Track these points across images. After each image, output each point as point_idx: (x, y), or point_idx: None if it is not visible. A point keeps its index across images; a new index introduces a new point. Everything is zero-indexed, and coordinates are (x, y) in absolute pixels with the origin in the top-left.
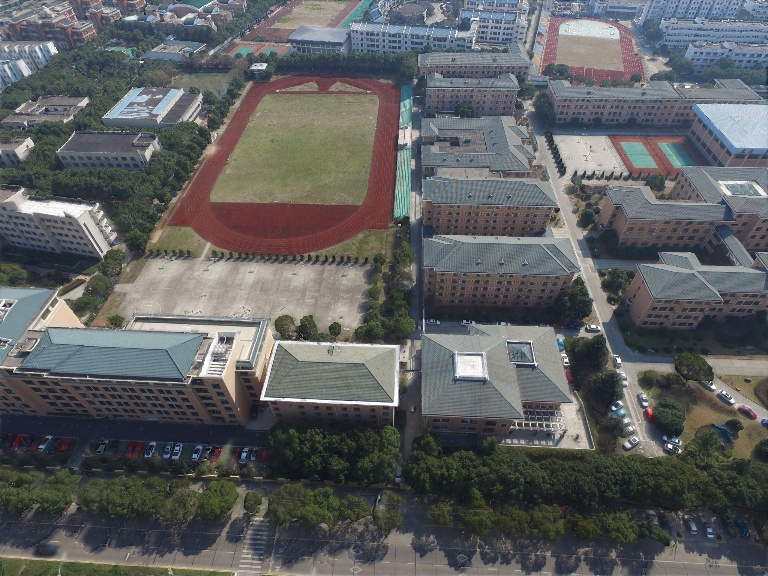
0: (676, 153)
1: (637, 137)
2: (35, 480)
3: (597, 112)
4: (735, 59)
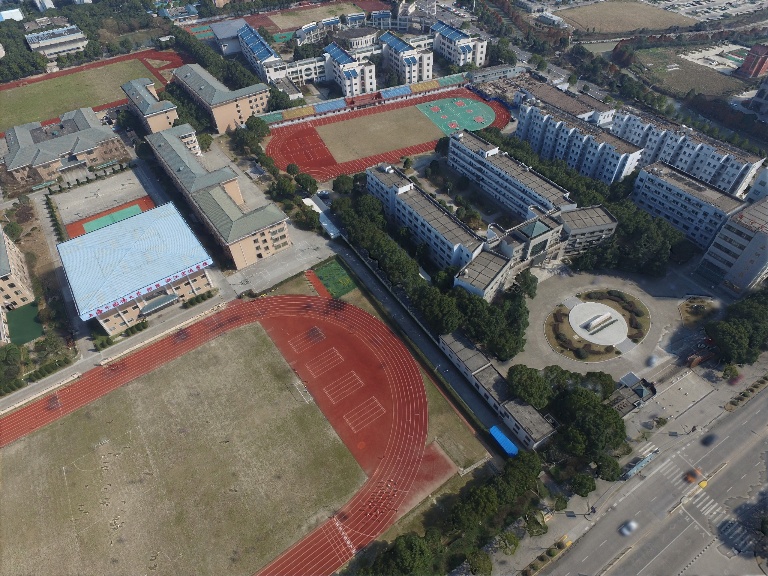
0: None
1: None
2: None
3: None
4: (399, 208)
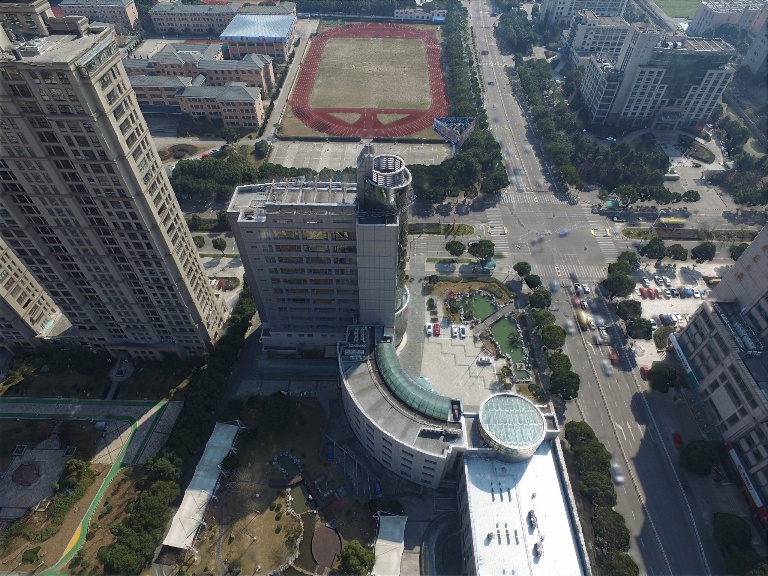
0: None
1: (206, 40)
2: None
3: (184, 24)
4: None
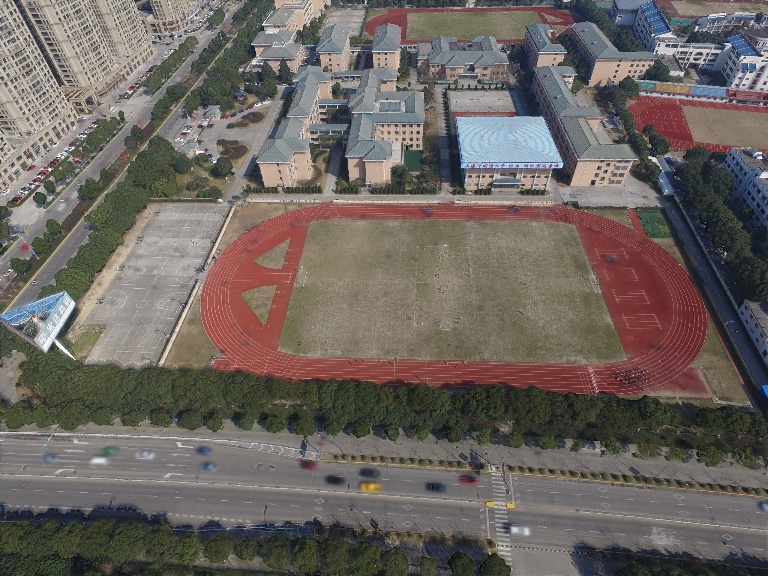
0: None
1: None
2: (266, 6)
3: (540, 97)
4: (751, 191)
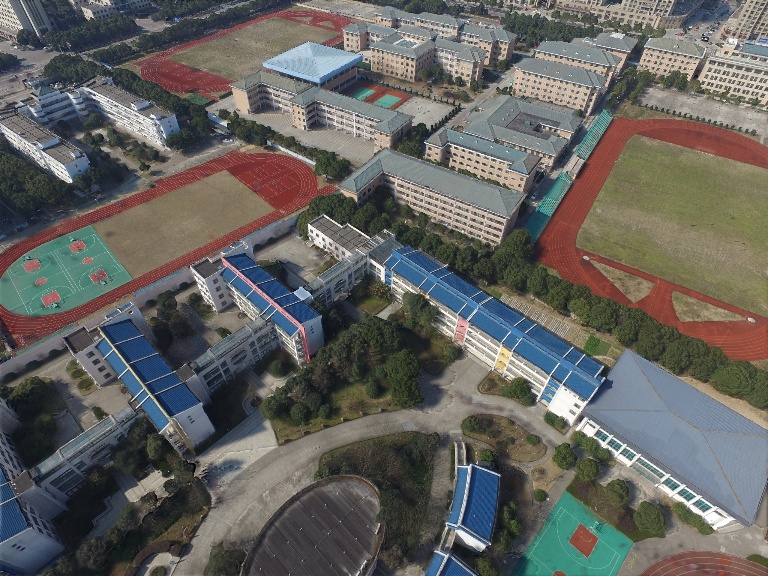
0: (356, 96)
1: None
2: None
3: None
4: None
